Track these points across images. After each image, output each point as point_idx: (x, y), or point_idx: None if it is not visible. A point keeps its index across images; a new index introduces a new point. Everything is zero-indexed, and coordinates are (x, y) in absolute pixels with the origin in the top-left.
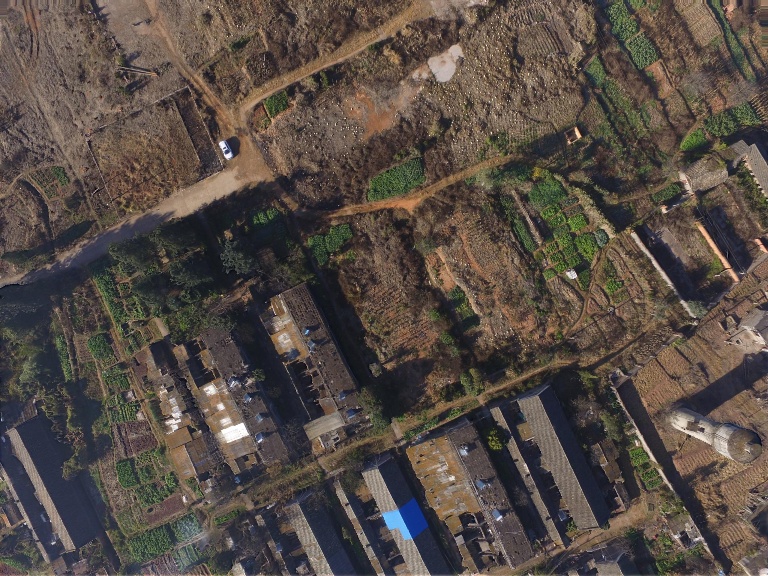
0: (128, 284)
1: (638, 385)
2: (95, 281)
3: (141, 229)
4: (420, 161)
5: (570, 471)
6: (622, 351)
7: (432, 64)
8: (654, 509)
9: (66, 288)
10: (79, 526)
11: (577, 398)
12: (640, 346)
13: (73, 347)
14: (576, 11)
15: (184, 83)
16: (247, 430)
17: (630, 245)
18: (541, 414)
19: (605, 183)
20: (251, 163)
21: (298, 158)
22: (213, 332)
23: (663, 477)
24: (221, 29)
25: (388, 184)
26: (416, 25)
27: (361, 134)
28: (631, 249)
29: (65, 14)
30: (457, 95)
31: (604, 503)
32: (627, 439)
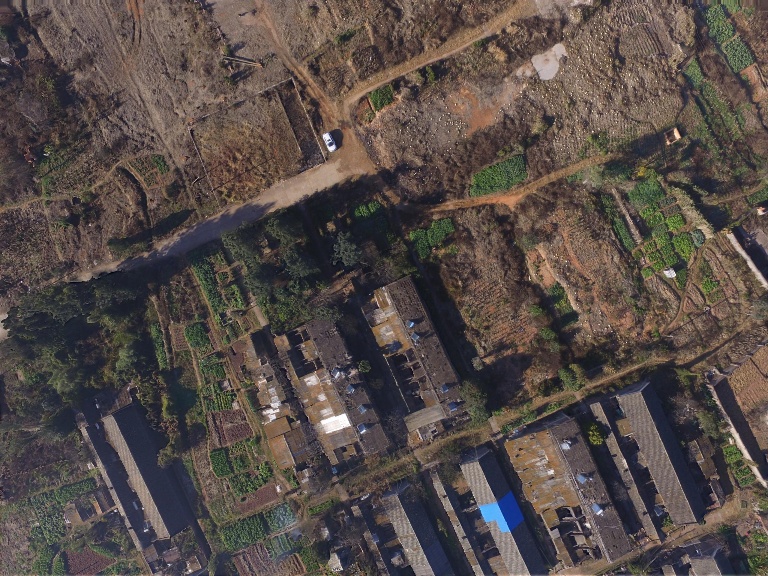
0: (227, 274)
1: (733, 384)
2: (193, 270)
3: (241, 219)
4: (523, 158)
5: (670, 467)
6: (718, 350)
7: (536, 62)
8: (747, 506)
9: (164, 276)
10: (173, 514)
11: (676, 395)
12: (735, 345)
13: (169, 335)
14: (676, 13)
15: (288, 74)
16: (349, 421)
17: (726, 246)
18: (642, 410)
19: (702, 184)
20: (354, 156)
21: (402, 152)
22: (318, 323)
23: (757, 475)
24: (327, 22)
25: (490, 180)
26: (521, 23)
27: (465, 130)
28: (727, 249)
29: (170, 3)
30: (560, 93)
31: (700, 499)
32: (721, 437)
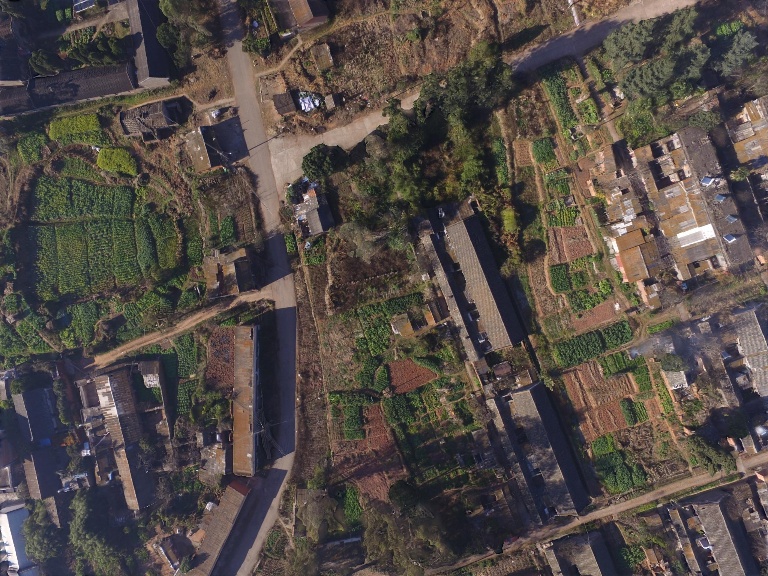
0: (579, 89)
1: None
2: (543, 85)
3: (596, 36)
4: None
5: None
6: None
7: None
8: None
9: (514, 90)
10: (512, 325)
11: None
12: None
13: (512, 151)
14: None
15: None
16: (715, 231)
17: None
18: None
19: None
20: None
21: None
22: (691, 131)
23: None
24: None
25: None
26: None
27: None
28: None
29: None
30: None
31: None
32: None
